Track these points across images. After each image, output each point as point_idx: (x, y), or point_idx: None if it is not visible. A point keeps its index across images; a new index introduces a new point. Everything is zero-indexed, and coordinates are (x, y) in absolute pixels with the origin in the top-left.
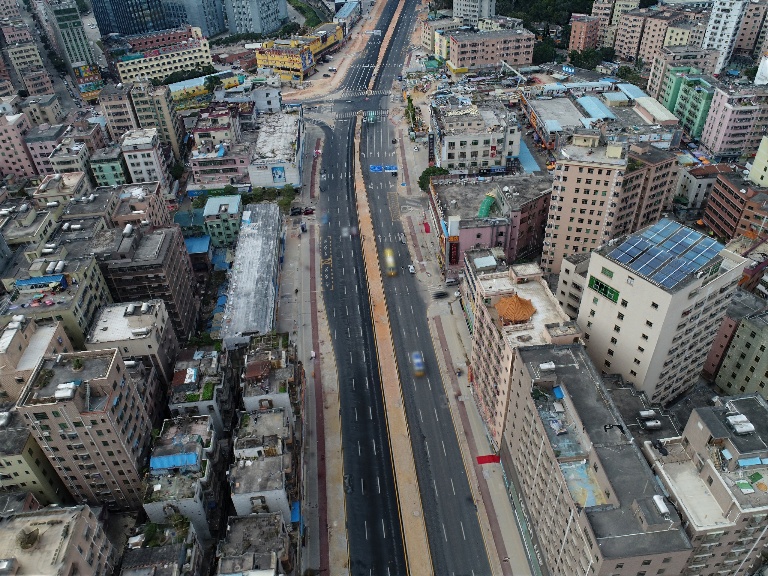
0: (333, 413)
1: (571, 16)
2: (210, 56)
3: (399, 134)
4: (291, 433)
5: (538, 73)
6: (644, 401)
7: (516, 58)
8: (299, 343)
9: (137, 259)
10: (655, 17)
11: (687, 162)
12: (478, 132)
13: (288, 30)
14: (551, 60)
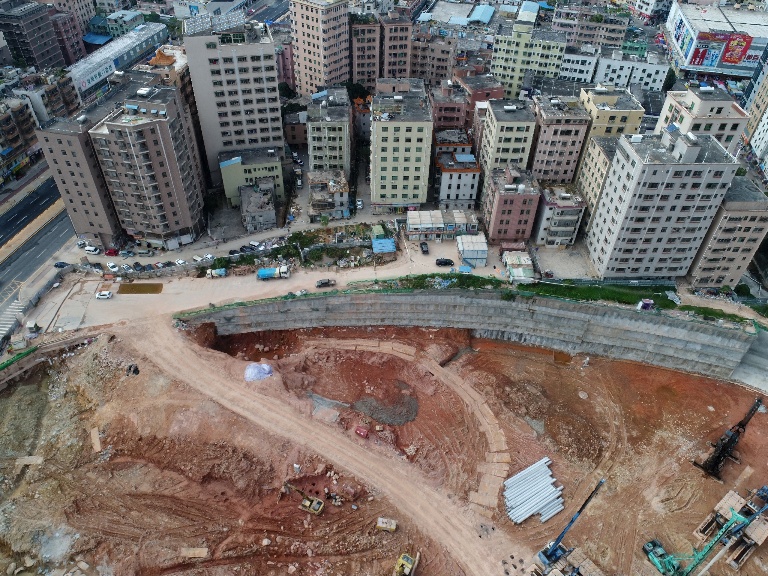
0: None
1: None
2: None
3: None
4: (18, 107)
5: None
6: None
7: None
8: None
9: (8, 11)
10: None
11: None
12: None
13: None
14: None
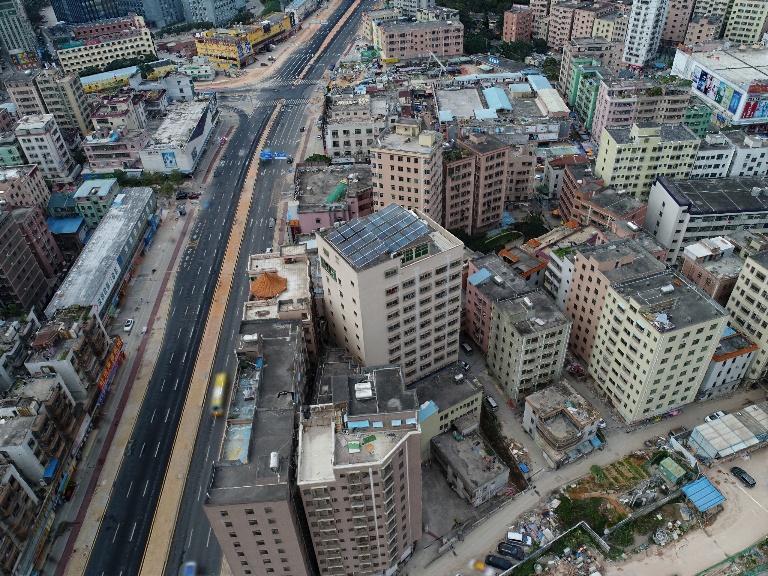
0: (142, 384)
1: (512, 7)
2: (152, 44)
3: (310, 123)
4: (53, 396)
5: (468, 64)
6: None
7: (446, 49)
8: (137, 319)
9: None
10: (584, 8)
11: (570, 153)
12: (362, 121)
13: (239, 19)
14: (484, 51)
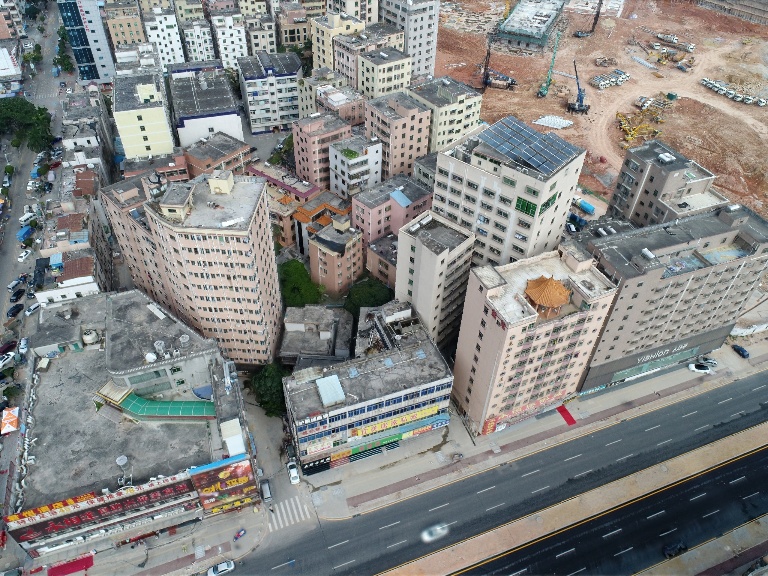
0: None
1: None
2: None
3: None
4: None
5: None
6: (584, 236)
7: None
8: None
9: None
10: None
11: None
12: None
13: None
14: None
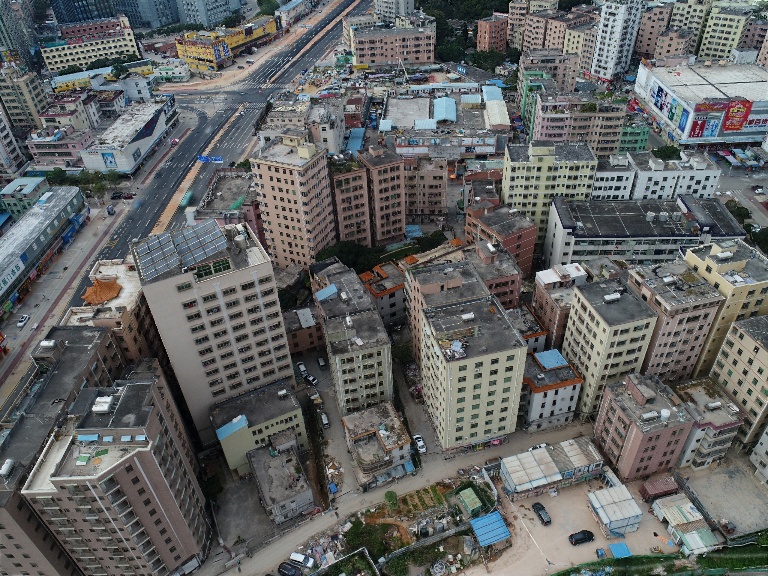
0: (15, 379)
1: None
2: (135, 45)
3: None
4: None
5: (438, 72)
6: None
7: (417, 56)
8: (33, 315)
9: None
10: (558, 19)
11: None
12: None
13: (228, 22)
14: (458, 59)
